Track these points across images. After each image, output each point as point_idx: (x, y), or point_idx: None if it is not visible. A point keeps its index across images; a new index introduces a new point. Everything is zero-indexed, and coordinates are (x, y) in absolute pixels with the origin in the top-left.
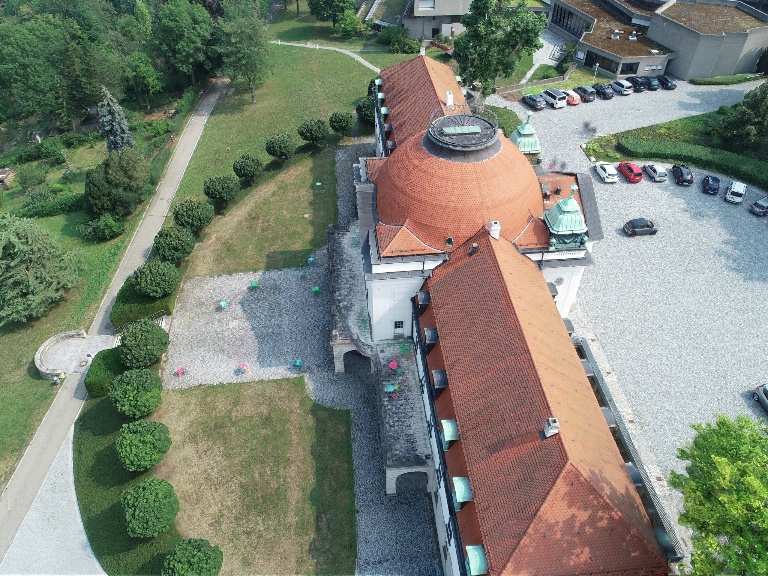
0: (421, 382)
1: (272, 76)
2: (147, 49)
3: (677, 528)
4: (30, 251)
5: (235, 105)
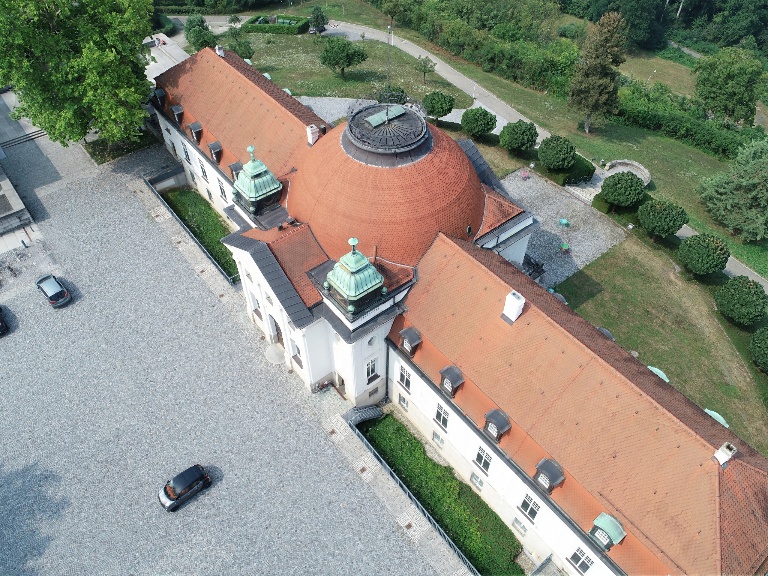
0: None
1: None
2: None
3: (146, 196)
4: None
5: None
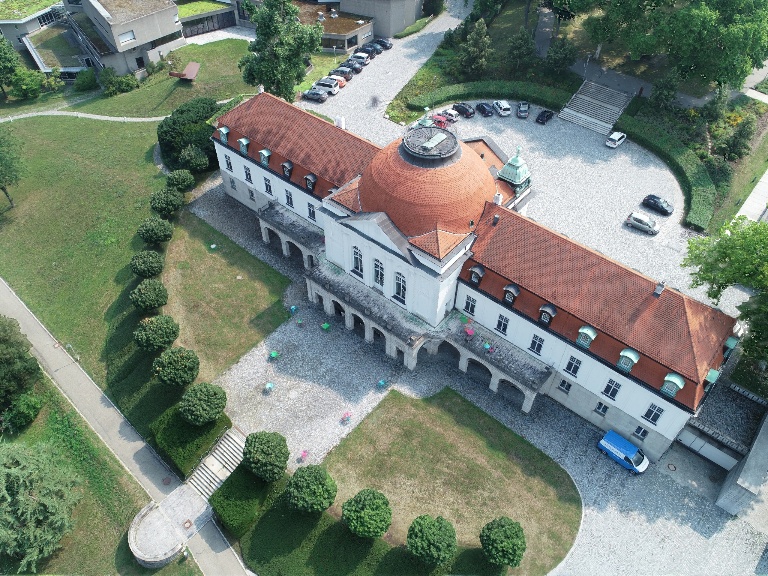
0: (497, 330)
1: None
2: None
3: None
4: None
5: None
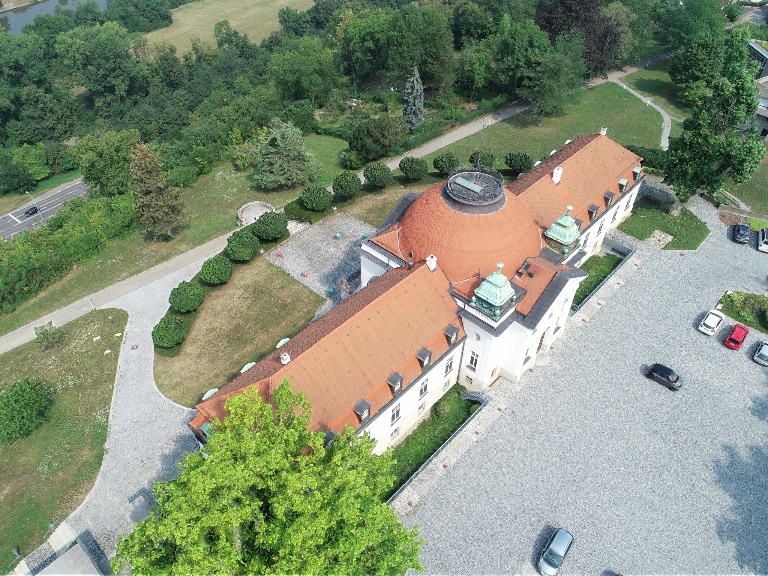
0: None
1: (579, 112)
2: (495, 54)
3: None
4: (284, 148)
5: (526, 122)
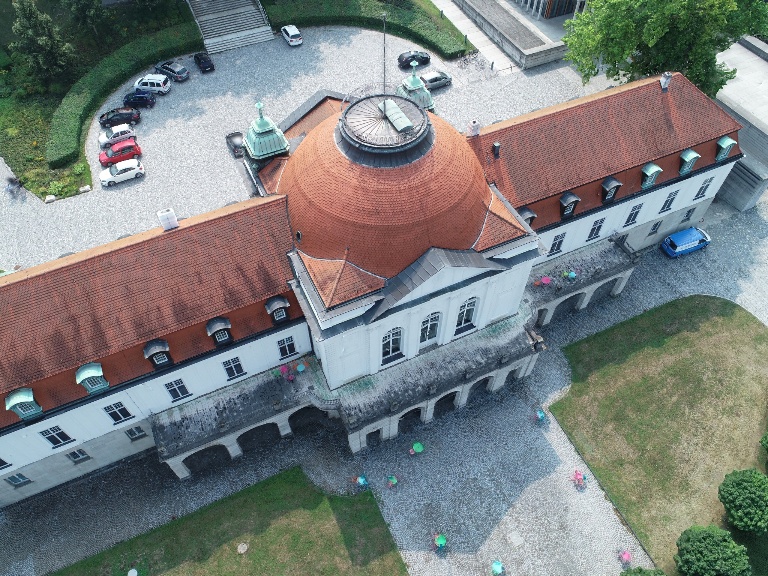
0: (551, 255)
1: None
2: None
3: None
4: None
5: None
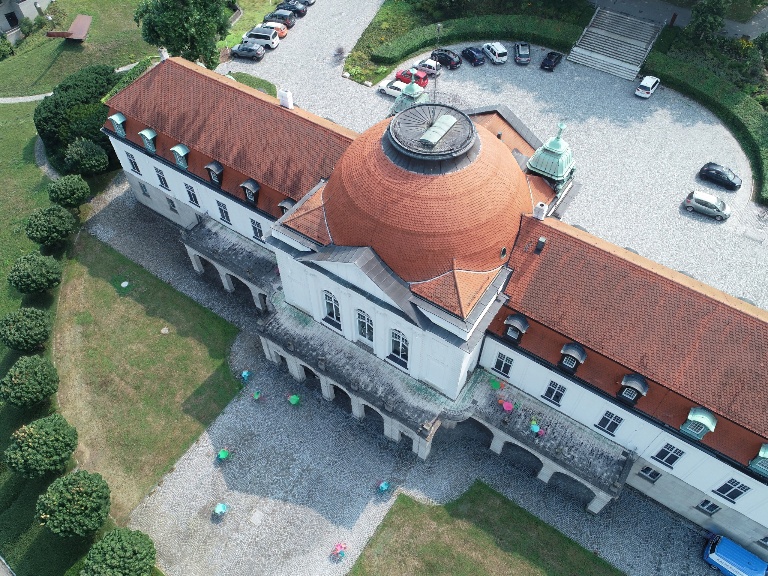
0: (545, 398)
1: None
2: None
3: None
4: None
5: None
